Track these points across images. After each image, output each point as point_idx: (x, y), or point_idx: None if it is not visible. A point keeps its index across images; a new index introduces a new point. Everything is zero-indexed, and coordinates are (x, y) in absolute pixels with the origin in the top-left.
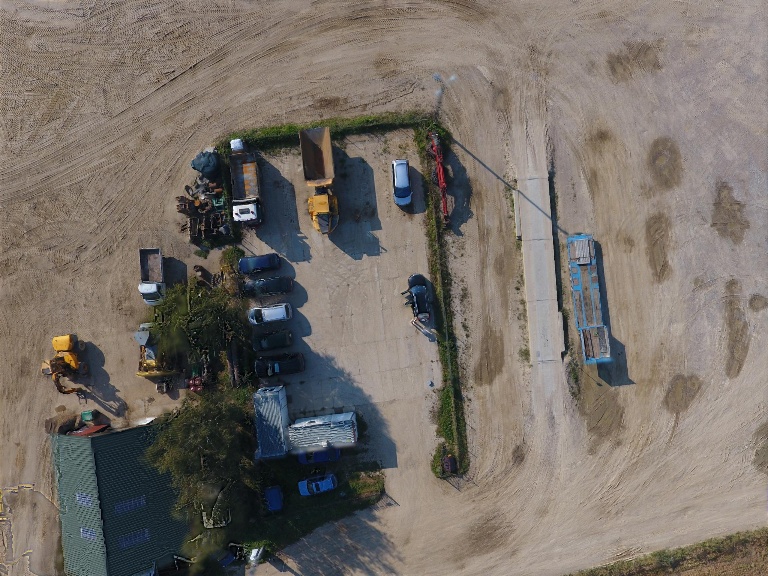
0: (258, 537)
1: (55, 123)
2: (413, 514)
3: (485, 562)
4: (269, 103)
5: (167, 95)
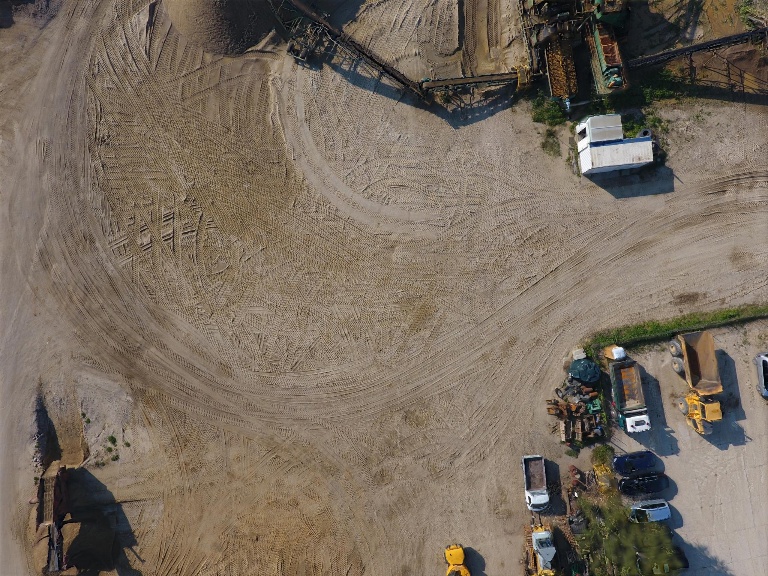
0: None
1: (422, 333)
2: None
3: None
4: (630, 302)
5: (530, 299)
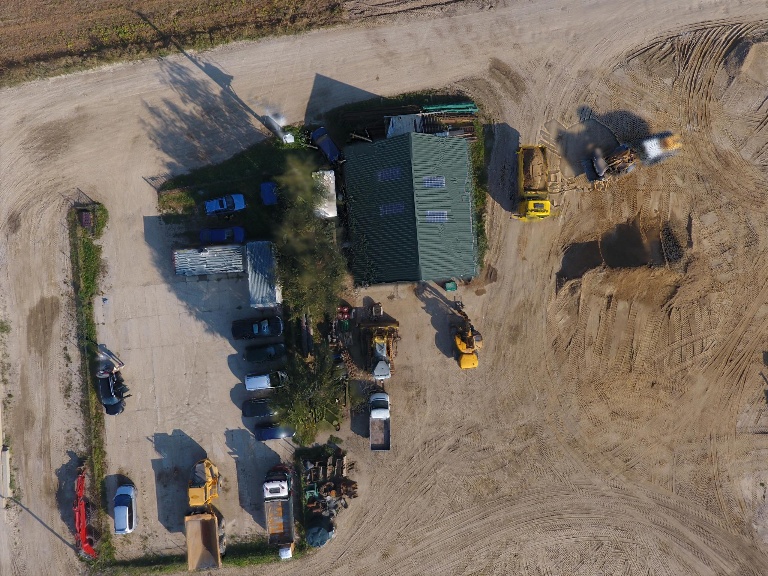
0: (290, 153)
1: (473, 570)
2: (128, 168)
3: (53, 113)
4: None
5: None
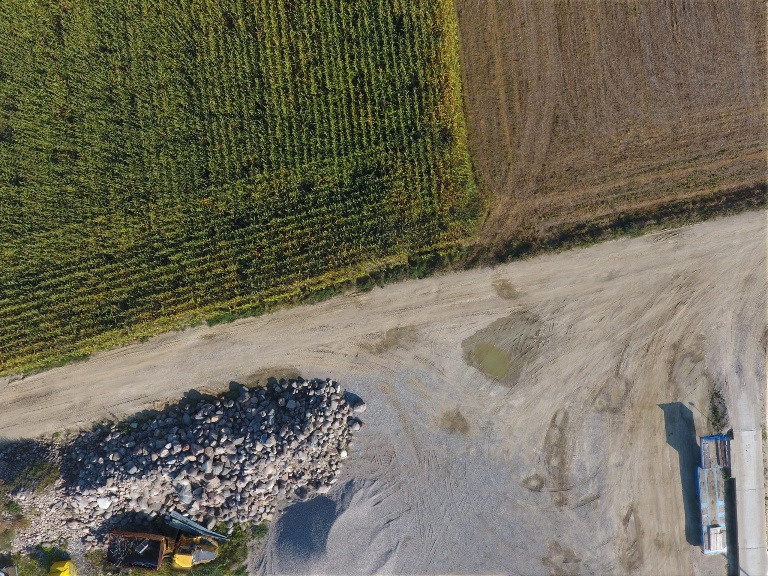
0: None
1: None
2: None
3: None
4: None
5: None
